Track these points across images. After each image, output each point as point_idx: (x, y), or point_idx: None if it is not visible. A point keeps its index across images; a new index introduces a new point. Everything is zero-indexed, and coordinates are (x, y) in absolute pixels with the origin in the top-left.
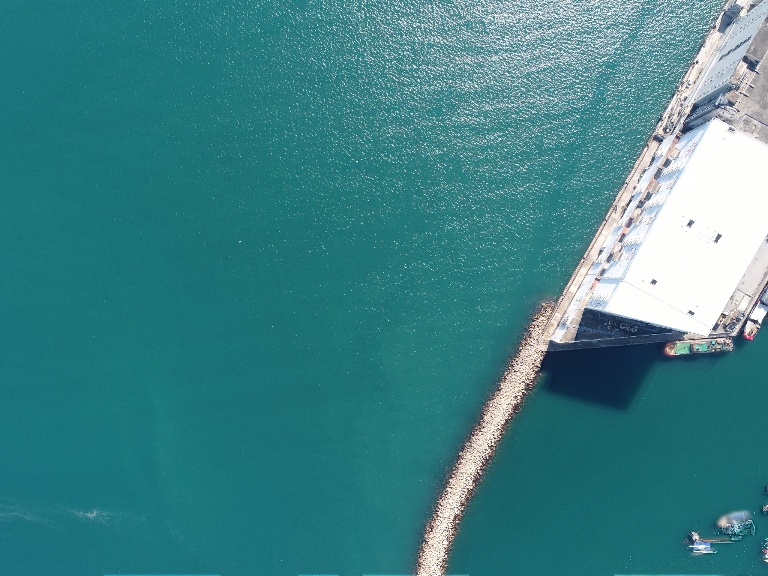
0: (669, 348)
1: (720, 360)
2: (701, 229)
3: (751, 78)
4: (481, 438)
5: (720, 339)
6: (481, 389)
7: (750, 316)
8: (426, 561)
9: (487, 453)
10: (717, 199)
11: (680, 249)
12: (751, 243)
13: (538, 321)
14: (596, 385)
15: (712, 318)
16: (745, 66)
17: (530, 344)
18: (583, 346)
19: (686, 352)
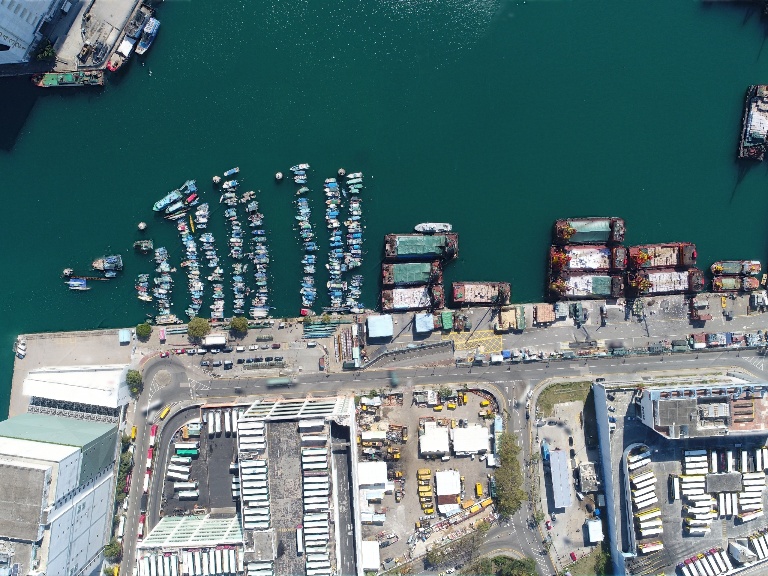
0: (37, 79)
1: (96, 96)
2: None
3: None
4: None
5: (89, 72)
6: None
7: (117, 49)
8: None
9: None
10: None
11: None
12: None
13: None
14: None
15: None
16: None
17: None
18: None
19: (54, 84)
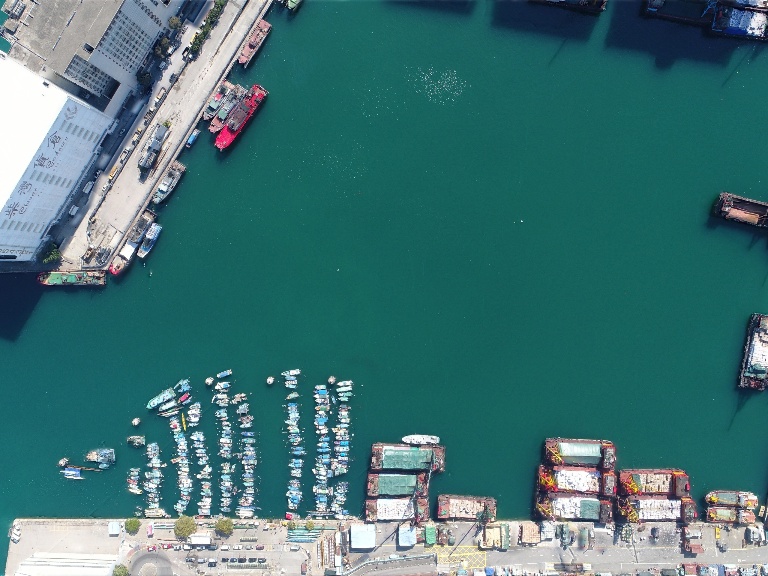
0: (43, 277)
1: (98, 293)
2: None
3: (31, 8)
4: None
5: (92, 272)
6: None
7: (120, 252)
8: None
9: None
10: None
11: None
12: (14, 166)
13: None
14: None
15: None
16: None
17: None
18: None
19: (59, 282)
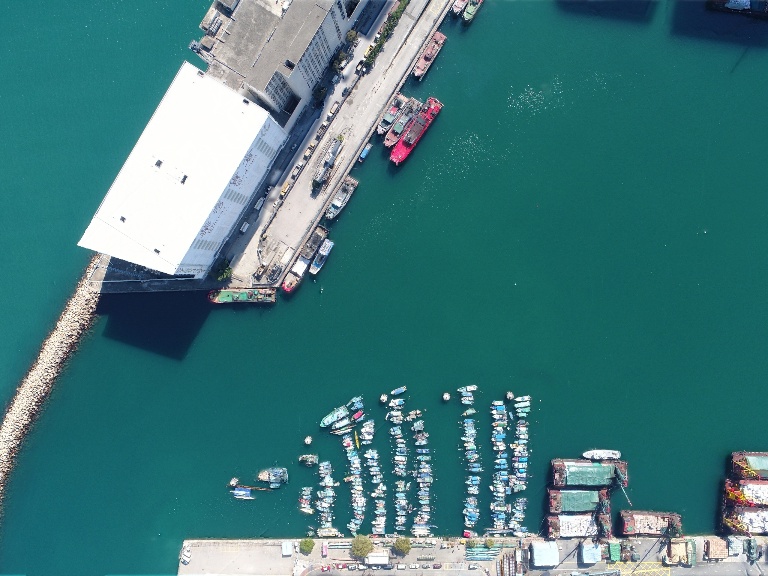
0: (213, 296)
1: (268, 311)
2: (169, 170)
3: (227, 25)
4: (34, 374)
5: (263, 289)
6: (43, 327)
7: (292, 268)
8: None
9: (42, 389)
10: (184, 141)
11: (148, 188)
12: (214, 185)
13: (93, 263)
14: (147, 329)
15: (176, 257)
16: (215, 12)
17: (84, 285)
18: (134, 289)
19: (229, 300)
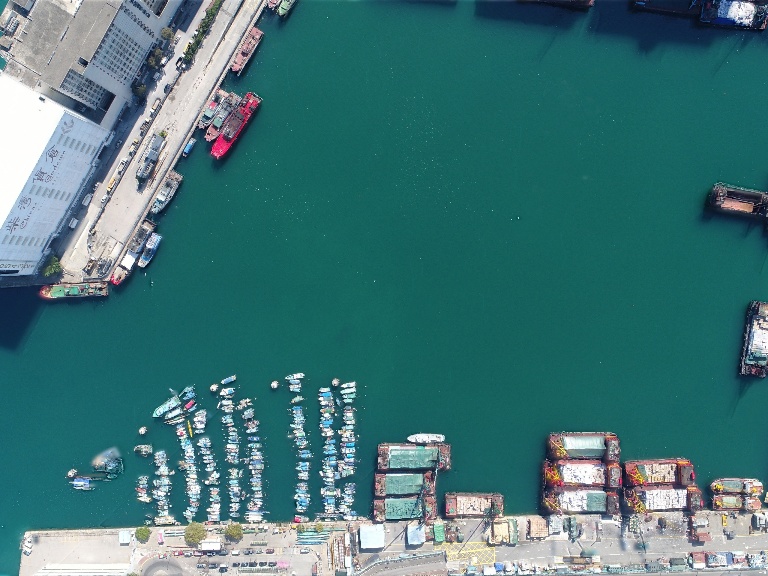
0: (46, 291)
1: (101, 305)
2: None
3: (24, 24)
4: None
5: (94, 284)
6: None
7: (121, 262)
8: None
9: None
10: None
11: None
12: (14, 182)
13: None
14: None
15: None
16: (10, 12)
17: None
18: None
19: (62, 295)
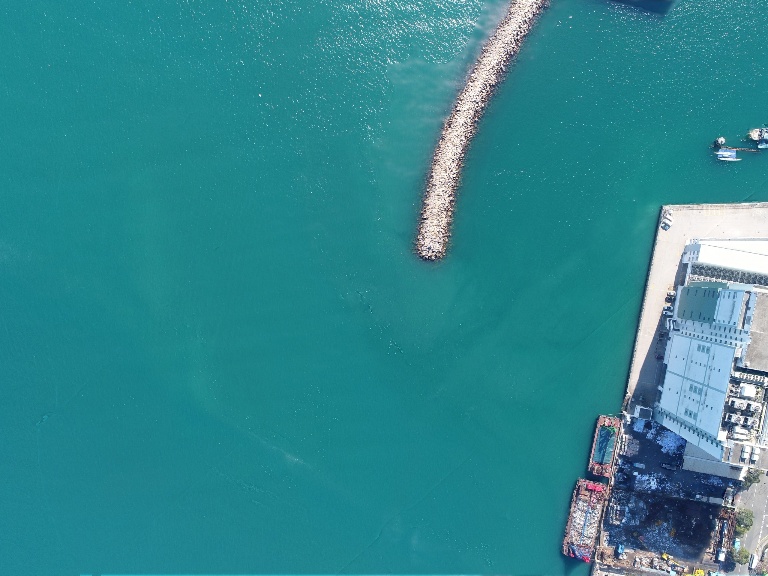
0: None
1: None
2: None
3: None
4: (507, 28)
5: None
6: None
7: None
8: (442, 157)
9: (512, 47)
10: None
11: None
12: None
13: None
14: None
15: None
16: None
17: None
18: None
19: None
